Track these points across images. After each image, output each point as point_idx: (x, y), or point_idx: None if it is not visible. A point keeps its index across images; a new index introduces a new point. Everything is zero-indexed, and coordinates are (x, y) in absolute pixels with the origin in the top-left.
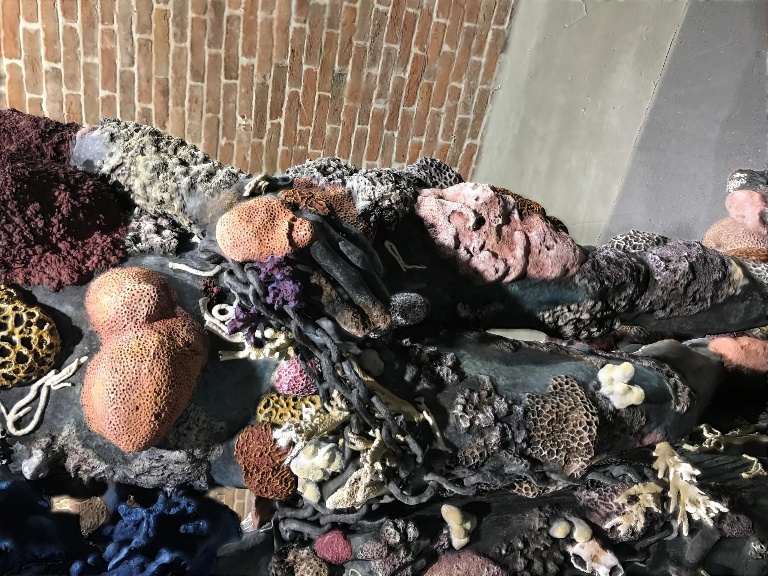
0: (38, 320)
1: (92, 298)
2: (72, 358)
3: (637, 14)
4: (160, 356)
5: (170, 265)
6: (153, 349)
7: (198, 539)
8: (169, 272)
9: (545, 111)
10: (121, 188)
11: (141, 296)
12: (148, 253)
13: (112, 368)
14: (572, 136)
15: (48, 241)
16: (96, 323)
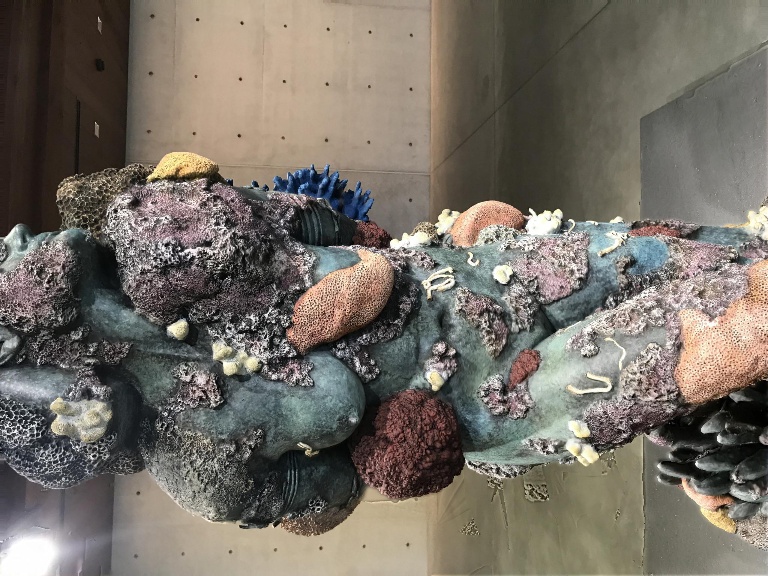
0: None
1: None
2: None
3: None
4: None
5: None
6: None
7: None
8: None
9: None
10: None
11: None
12: None
13: None
14: None
15: None
16: None
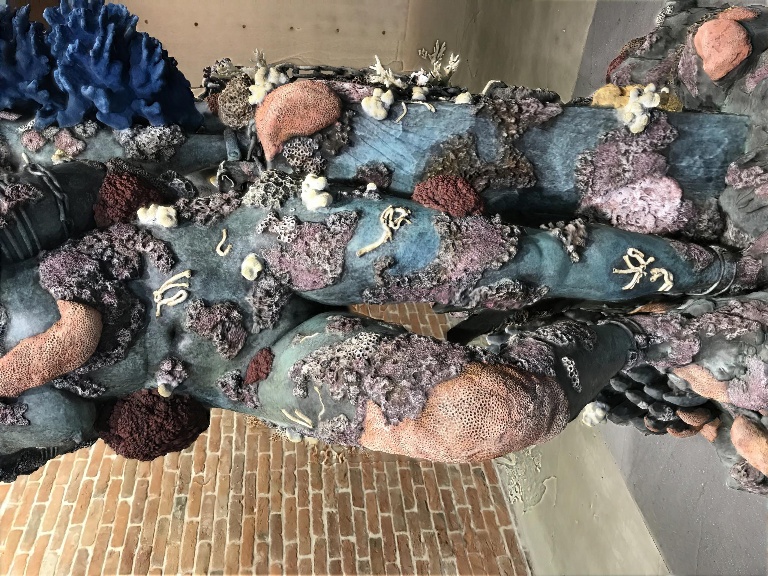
0: None
1: None
2: None
3: (571, 425)
4: None
5: None
6: None
7: None
8: None
9: (584, 572)
10: None
11: None
12: None
13: None
14: (604, 544)
15: None
16: None
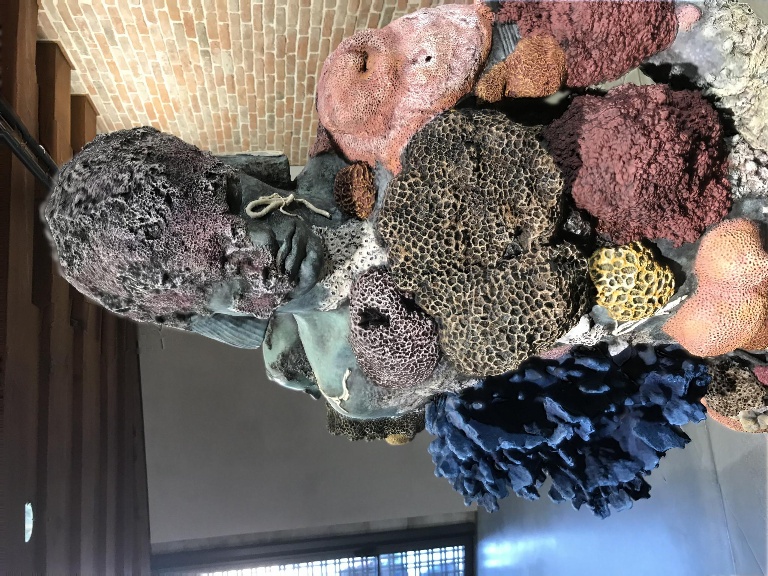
0: (670, 280)
1: (706, 254)
2: (676, 296)
3: None
4: (761, 317)
5: (764, 211)
6: (759, 314)
7: (705, 387)
8: (761, 218)
9: None
10: (730, 115)
11: (762, 271)
12: (746, 197)
13: (720, 321)
14: None
15: (683, 205)
16: (701, 271)
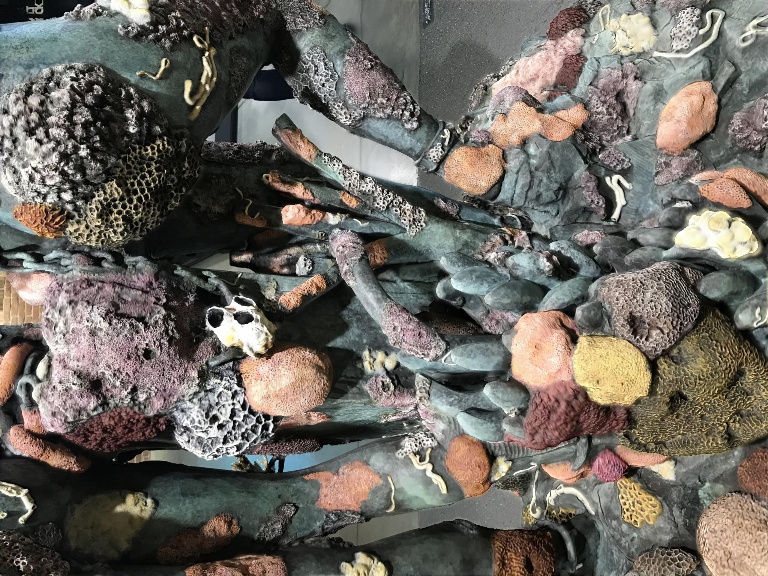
0: None
1: None
2: None
3: None
4: None
5: None
6: None
7: None
8: None
9: None
10: None
11: None
12: None
13: None
14: None
15: None
16: None
